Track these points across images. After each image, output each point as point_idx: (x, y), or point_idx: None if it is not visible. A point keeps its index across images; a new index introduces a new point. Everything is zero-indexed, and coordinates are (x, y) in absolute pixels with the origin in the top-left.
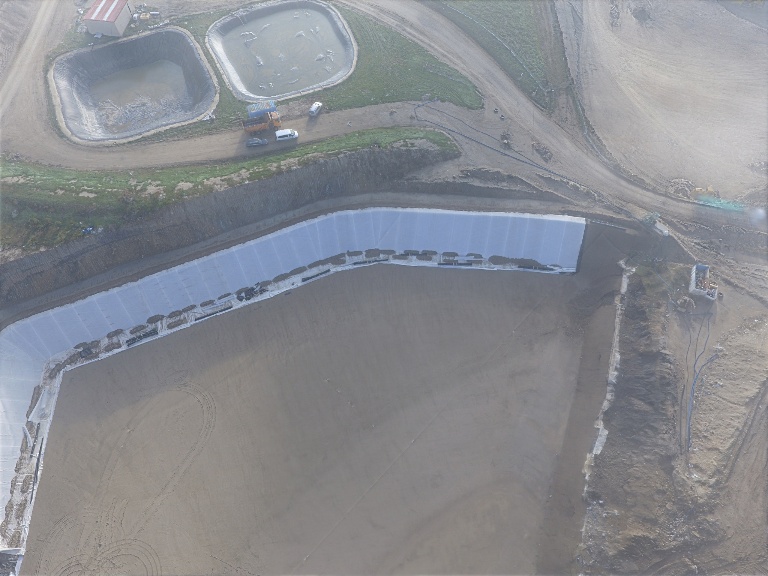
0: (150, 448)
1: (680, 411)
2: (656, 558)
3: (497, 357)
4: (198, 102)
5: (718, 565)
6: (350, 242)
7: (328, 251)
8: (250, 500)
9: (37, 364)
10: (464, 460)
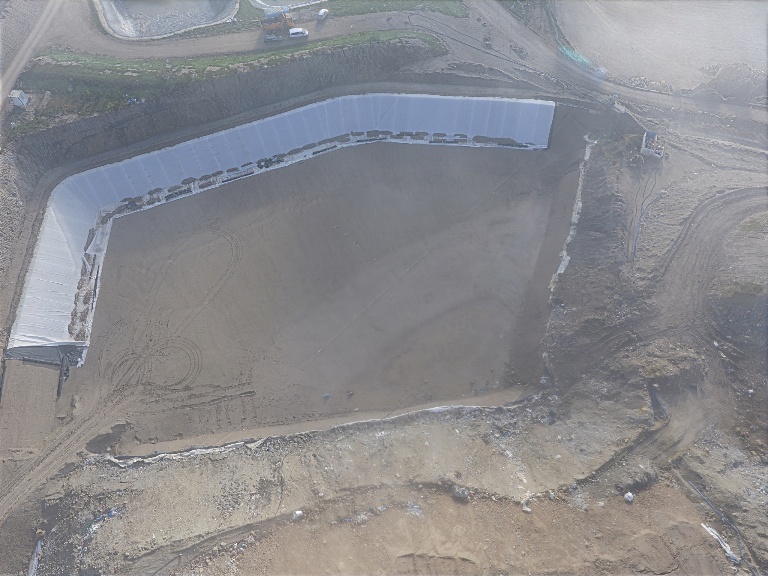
0: (189, 273)
1: (628, 234)
2: (604, 333)
3: (479, 210)
4: (220, 12)
5: (653, 333)
6: (354, 124)
7: (335, 131)
8: (273, 310)
9: (91, 212)
10: (451, 284)
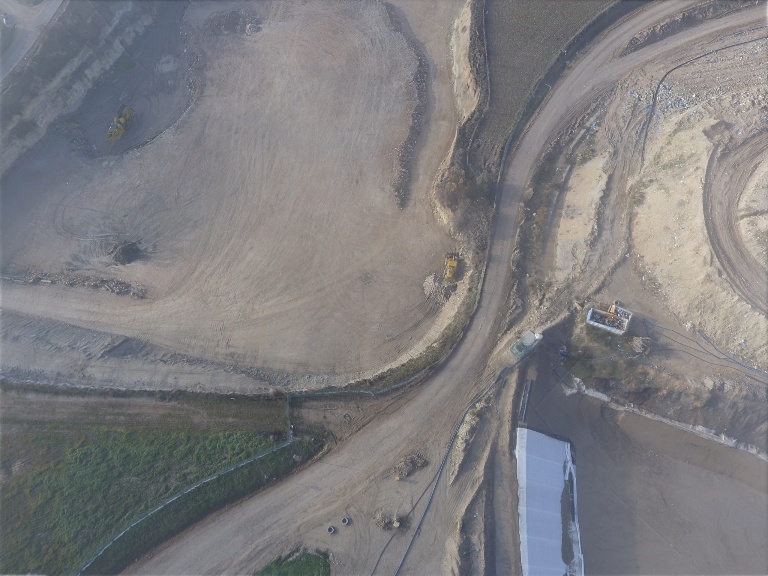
0: None
1: None
2: None
3: (713, 575)
4: None
5: None
6: None
7: None
8: None
9: None
10: None
